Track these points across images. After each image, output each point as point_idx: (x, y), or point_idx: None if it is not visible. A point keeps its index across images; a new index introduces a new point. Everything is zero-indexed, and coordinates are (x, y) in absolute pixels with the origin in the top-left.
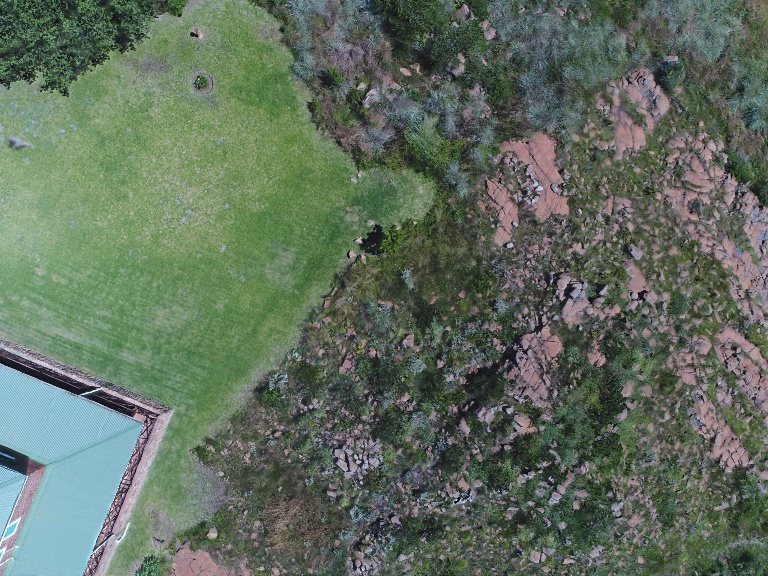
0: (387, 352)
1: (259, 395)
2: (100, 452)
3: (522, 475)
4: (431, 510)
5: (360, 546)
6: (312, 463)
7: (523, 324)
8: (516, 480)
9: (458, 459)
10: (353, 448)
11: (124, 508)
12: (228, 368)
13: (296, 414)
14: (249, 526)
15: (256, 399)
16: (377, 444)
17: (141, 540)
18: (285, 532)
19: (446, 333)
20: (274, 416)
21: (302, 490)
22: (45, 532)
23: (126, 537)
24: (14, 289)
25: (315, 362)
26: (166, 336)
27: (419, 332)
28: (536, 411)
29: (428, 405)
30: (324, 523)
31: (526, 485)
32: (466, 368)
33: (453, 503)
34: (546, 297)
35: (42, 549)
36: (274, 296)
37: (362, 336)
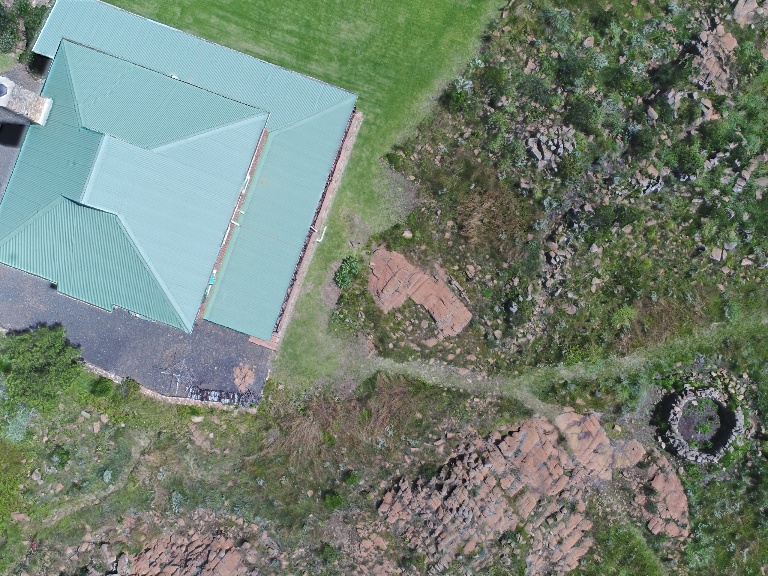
0: (569, 53)
1: (446, 99)
2: (318, 122)
3: (708, 160)
4: (620, 201)
5: (555, 236)
6: (504, 157)
7: (697, 25)
8: (703, 165)
9: (651, 138)
10: (548, 134)
11: (325, 205)
12: (413, 79)
13: (483, 116)
14: (442, 227)
15: (442, 106)
16: (571, 129)
17: (338, 243)
18: (480, 226)
19: (624, 34)
20: (461, 120)
21: (495, 184)
22: (268, 200)
23: (323, 241)
24: (203, 9)
25: (499, 66)
26: (352, 49)
27: (598, 34)
28: (720, 96)
29: (616, 94)
30: (518, 215)
31: (711, 172)
32: (646, 65)
33: (642, 192)
34: (716, 1)
35: (266, 217)
36: (453, 11)
37: (542, 41)
